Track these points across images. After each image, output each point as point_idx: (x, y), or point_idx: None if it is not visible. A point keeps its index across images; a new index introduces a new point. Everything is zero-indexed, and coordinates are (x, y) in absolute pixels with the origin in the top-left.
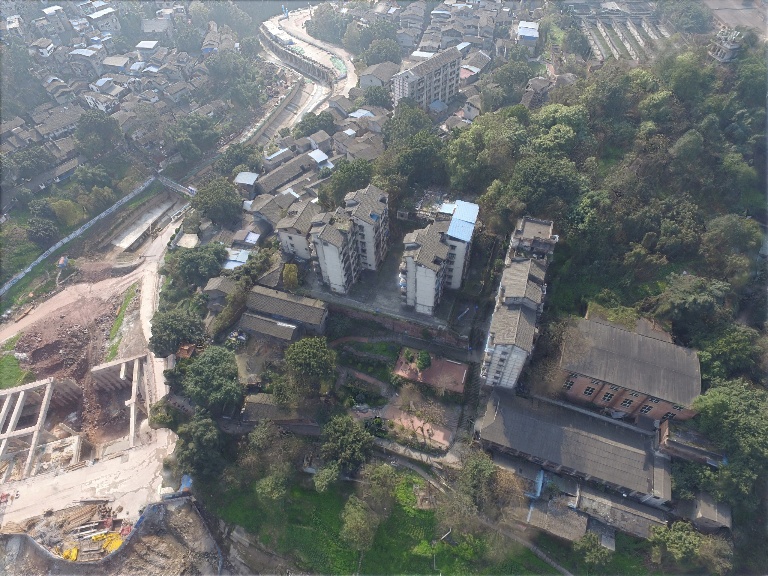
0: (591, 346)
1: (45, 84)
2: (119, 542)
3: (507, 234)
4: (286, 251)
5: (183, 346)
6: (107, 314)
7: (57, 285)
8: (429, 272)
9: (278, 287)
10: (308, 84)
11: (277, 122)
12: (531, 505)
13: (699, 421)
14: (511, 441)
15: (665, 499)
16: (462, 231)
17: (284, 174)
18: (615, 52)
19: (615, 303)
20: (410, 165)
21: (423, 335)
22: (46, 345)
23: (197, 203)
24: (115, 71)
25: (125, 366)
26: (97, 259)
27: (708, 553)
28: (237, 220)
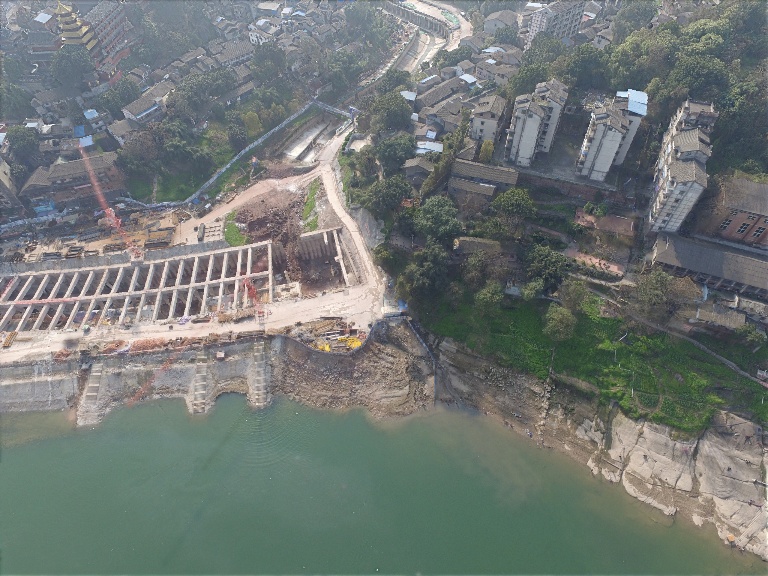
0: (746, 193)
1: (215, 23)
2: (359, 342)
3: (661, 123)
4: (473, 137)
5: (405, 199)
6: (298, 201)
7: (251, 179)
8: (617, 136)
9: (474, 160)
10: (422, 35)
11: (402, 64)
12: (698, 308)
13: None
14: (682, 262)
15: None
16: (639, 108)
17: (439, 93)
18: (718, 2)
19: (758, 170)
20: (578, 69)
21: (595, 197)
22: (257, 219)
23: (379, 109)
24: (267, 15)
25: (326, 234)
26: (277, 163)
27: None
28: (409, 125)
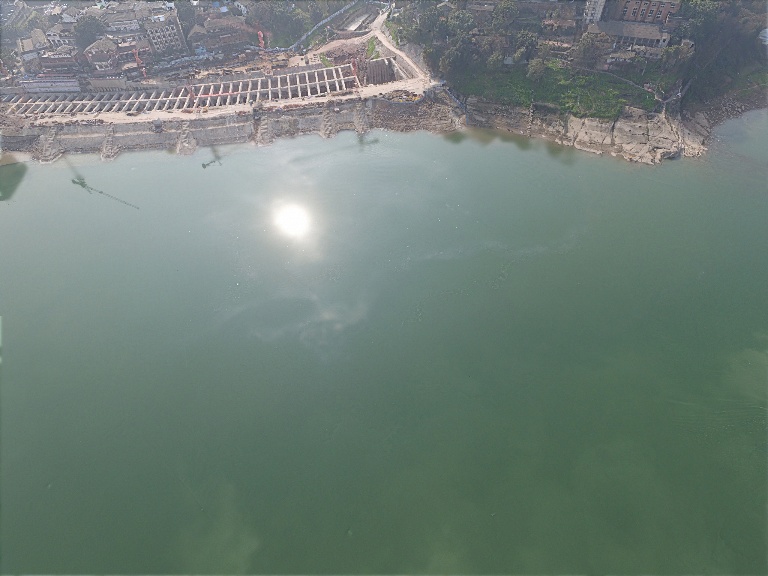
0: None
1: None
2: None
3: None
4: None
5: None
6: (362, 48)
7: (327, 40)
8: None
9: None
10: None
11: None
12: (611, 53)
13: (681, 8)
14: (601, 31)
15: (668, 40)
16: None
17: None
18: None
19: None
20: None
21: None
22: (339, 56)
23: None
24: None
25: None
26: None
27: (685, 53)
28: None
